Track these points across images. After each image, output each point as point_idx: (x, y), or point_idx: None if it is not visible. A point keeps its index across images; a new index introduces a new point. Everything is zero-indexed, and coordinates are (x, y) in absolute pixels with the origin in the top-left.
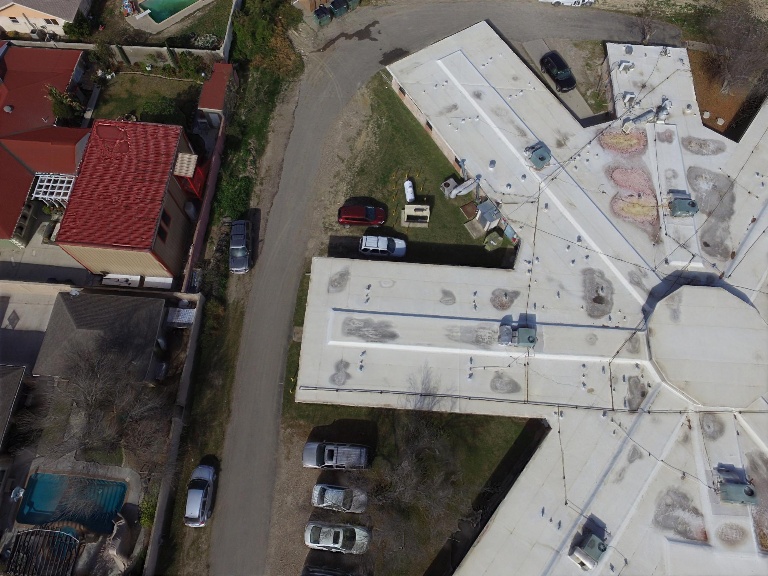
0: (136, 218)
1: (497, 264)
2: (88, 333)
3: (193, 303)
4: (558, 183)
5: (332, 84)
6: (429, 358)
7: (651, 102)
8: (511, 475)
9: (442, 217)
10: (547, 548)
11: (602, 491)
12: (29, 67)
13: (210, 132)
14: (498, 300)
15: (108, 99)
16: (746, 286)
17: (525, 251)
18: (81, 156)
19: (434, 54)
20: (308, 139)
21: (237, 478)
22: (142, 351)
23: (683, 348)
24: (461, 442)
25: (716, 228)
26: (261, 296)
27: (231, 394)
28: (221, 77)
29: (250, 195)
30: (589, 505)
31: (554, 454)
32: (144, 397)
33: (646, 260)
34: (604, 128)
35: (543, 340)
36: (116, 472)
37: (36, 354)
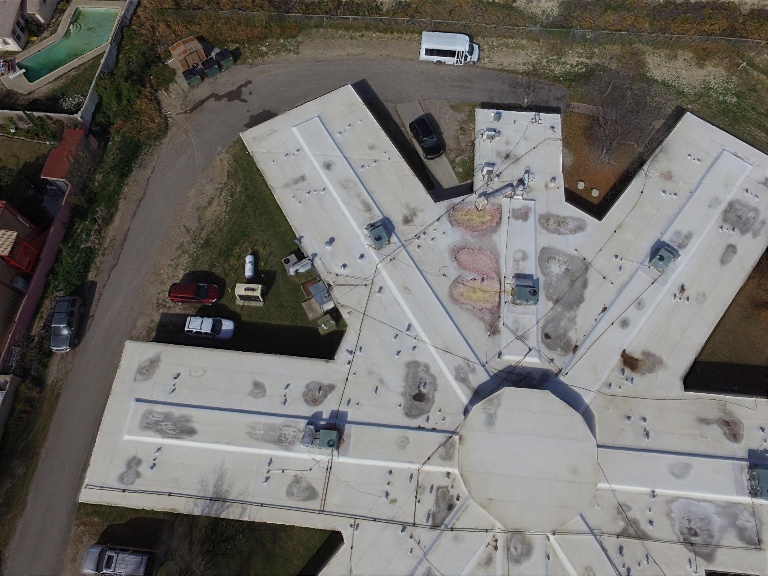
0: None
1: (330, 348)
2: None
3: None
4: (396, 264)
5: (192, 148)
6: (226, 458)
7: (512, 174)
8: None
9: (280, 295)
10: None
11: None
12: None
13: (61, 198)
14: (311, 394)
15: None
16: (583, 386)
17: (349, 339)
18: None
19: (291, 120)
20: (157, 207)
21: None
22: None
23: (493, 460)
24: (259, 548)
25: (561, 318)
26: (80, 377)
27: (31, 484)
28: (70, 144)
29: (90, 266)
30: None
31: (342, 573)
32: None
33: (478, 353)
34: (456, 203)
35: (350, 442)
36: None
37: None
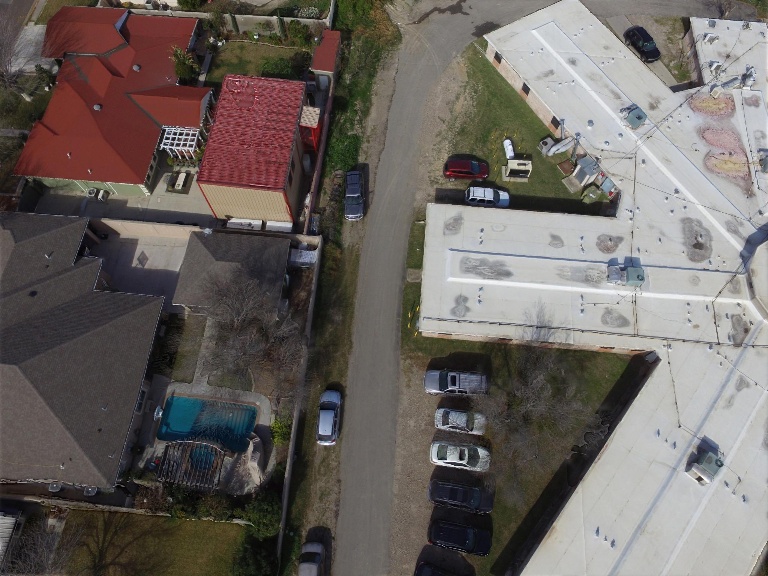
0: (269, 162)
1: None
2: (226, 265)
3: (312, 246)
4: (653, 141)
5: (429, 53)
6: (542, 295)
7: (736, 70)
8: (619, 405)
9: (540, 173)
10: (664, 466)
11: (713, 416)
12: (150, 32)
13: (317, 94)
14: (603, 244)
15: (220, 64)
16: None
17: (626, 201)
18: (204, 111)
19: (528, 25)
20: (410, 102)
21: (362, 402)
22: (274, 284)
23: None
24: (571, 375)
25: None
26: (374, 241)
27: (352, 328)
28: (331, 43)
29: (358, 151)
30: (702, 428)
31: (665, 382)
32: (290, 318)
33: (741, 211)
34: (693, 93)
35: (649, 280)
36: (247, 396)
37: (167, 289)
